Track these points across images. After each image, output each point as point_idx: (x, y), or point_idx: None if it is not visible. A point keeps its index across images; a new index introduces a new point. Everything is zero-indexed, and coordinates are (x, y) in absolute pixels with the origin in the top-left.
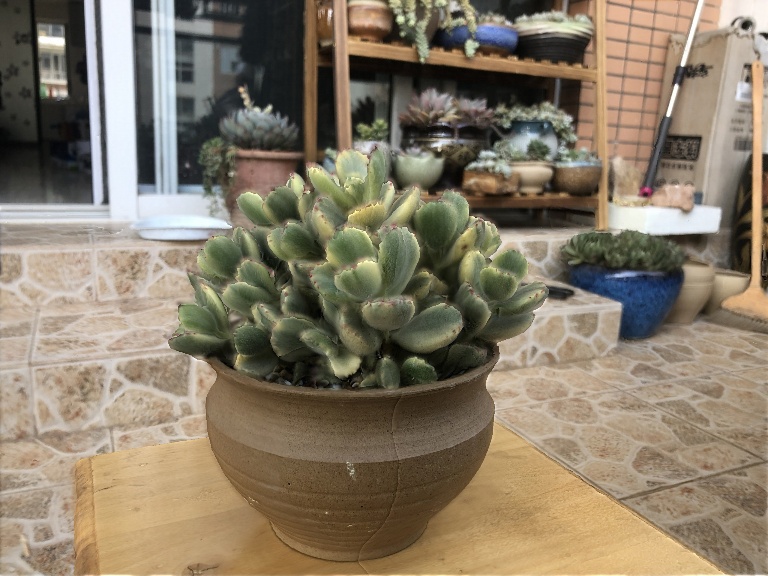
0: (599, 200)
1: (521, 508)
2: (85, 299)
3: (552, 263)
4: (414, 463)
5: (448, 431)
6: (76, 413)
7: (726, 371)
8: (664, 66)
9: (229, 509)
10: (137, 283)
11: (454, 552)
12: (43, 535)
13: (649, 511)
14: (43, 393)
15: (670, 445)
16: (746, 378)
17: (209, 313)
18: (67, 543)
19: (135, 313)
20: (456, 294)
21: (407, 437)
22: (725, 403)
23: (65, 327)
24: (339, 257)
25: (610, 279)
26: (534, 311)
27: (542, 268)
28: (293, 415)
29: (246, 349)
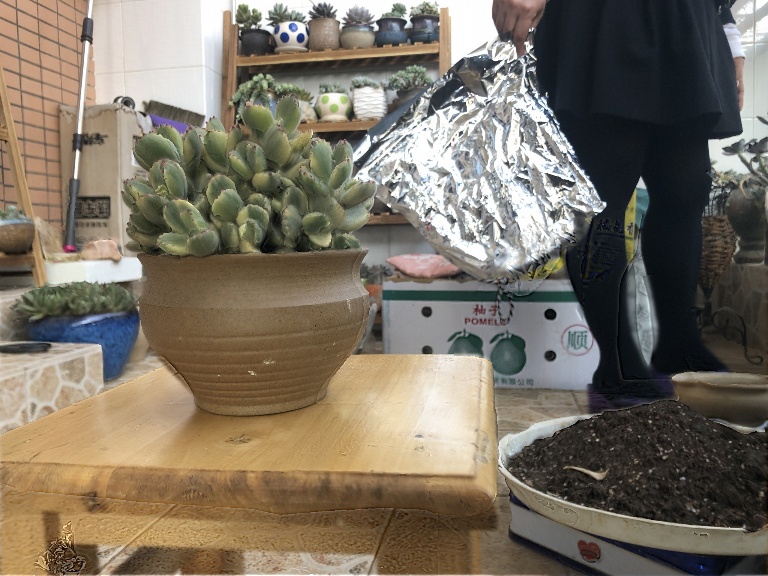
0: (35, 258)
1: None
2: None
3: (3, 326)
4: (366, 299)
5: None
6: None
7: None
8: (59, 133)
9: (180, 423)
10: None
11: (350, 386)
12: None
13: None
14: None
15: None
16: None
17: None
18: None
19: None
20: None
21: (358, 284)
22: None
23: None
24: (318, 159)
25: (78, 327)
26: (26, 365)
27: None
28: (308, 275)
29: None
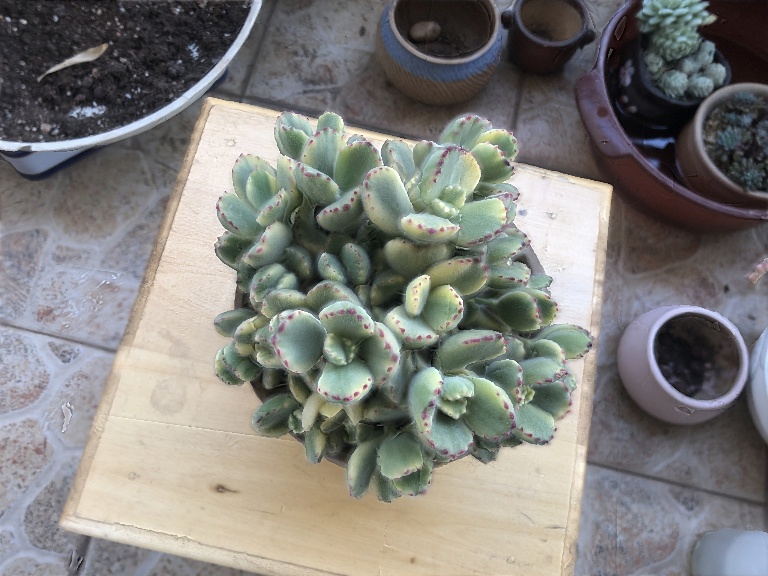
0: None
1: None
2: None
3: None
4: None
5: None
6: None
7: None
8: None
9: None
10: None
11: None
12: None
13: None
14: None
15: None
16: None
17: None
18: None
19: None
20: None
21: None
22: None
23: None
24: None
25: None
26: None
27: None
28: None
29: None
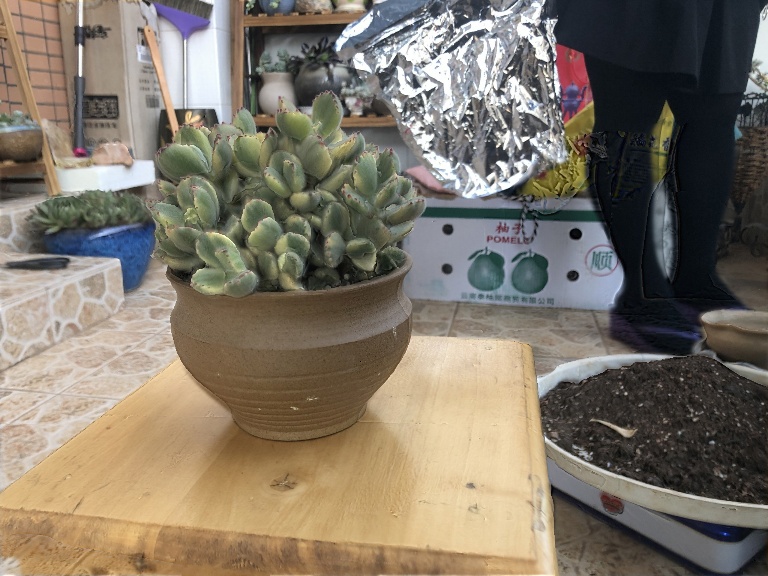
0: (46, 165)
1: None
2: None
3: (19, 237)
4: (411, 317)
5: None
6: None
7: None
8: (59, 25)
9: (220, 451)
10: None
11: (390, 391)
12: None
13: None
14: None
15: None
16: None
17: None
18: None
19: None
20: None
21: (403, 302)
22: None
23: None
24: (363, 177)
25: (95, 239)
26: (47, 285)
27: (11, 244)
28: (352, 308)
29: None
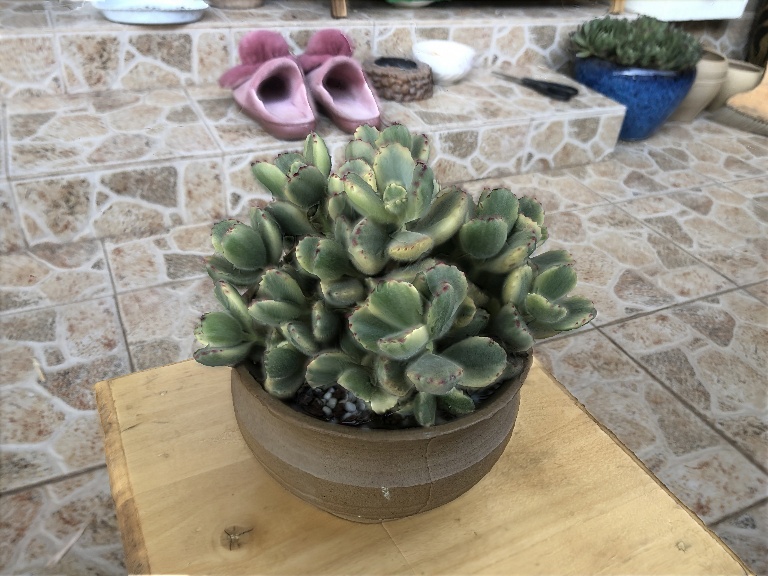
0: None
1: (530, 452)
2: (53, 92)
3: (558, 51)
4: (446, 481)
5: (479, 444)
6: (65, 226)
7: (718, 182)
8: None
9: None
10: (108, 73)
11: (469, 510)
12: (54, 359)
13: (624, 339)
14: (27, 207)
15: (652, 268)
16: (736, 191)
17: (233, 319)
18: (79, 367)
19: (111, 111)
20: (499, 317)
21: (440, 459)
22: (711, 221)
23: (38, 130)
24: (382, 309)
25: (618, 76)
26: (535, 116)
27: (547, 57)
28: (329, 442)
29: (278, 375)
